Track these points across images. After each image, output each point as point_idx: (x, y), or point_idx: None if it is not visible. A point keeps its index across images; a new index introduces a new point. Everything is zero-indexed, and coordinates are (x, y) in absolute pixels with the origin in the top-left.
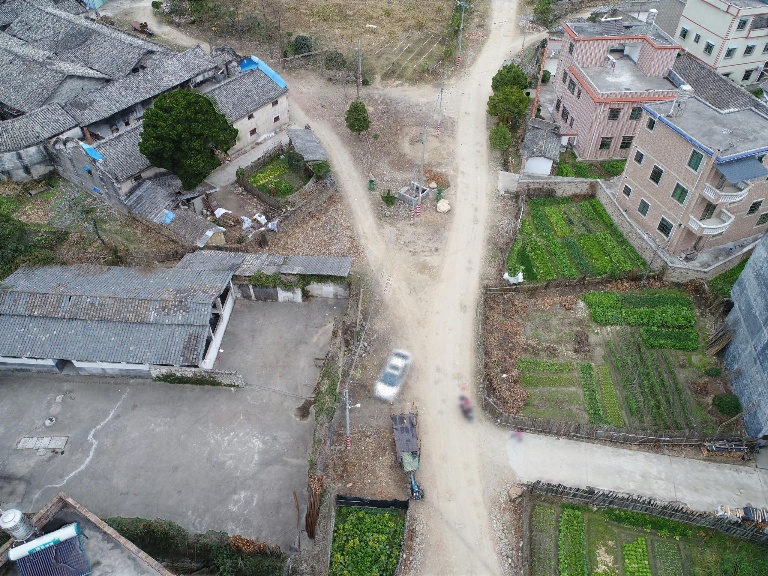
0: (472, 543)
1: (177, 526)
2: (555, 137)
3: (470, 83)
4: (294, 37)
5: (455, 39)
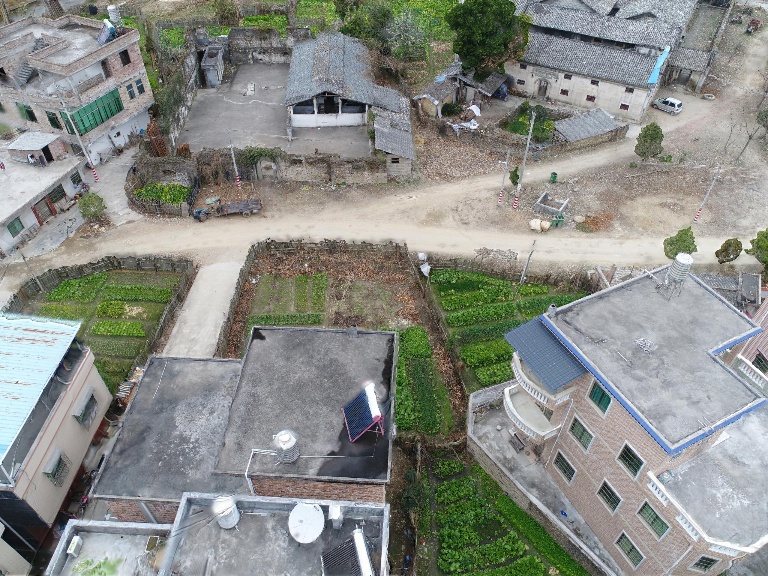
0: (160, 243)
1: (166, 107)
2: None
3: None
4: None
5: None
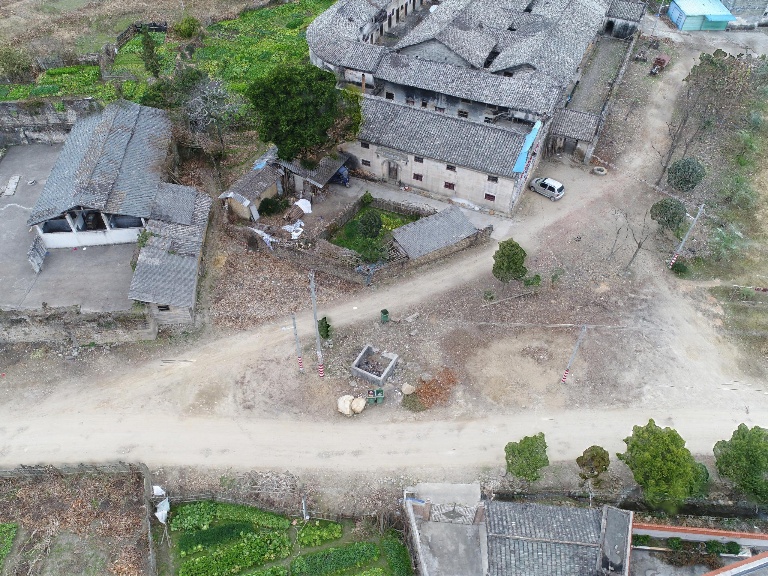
0: None
1: None
2: (584, 567)
3: None
4: (767, 175)
5: None
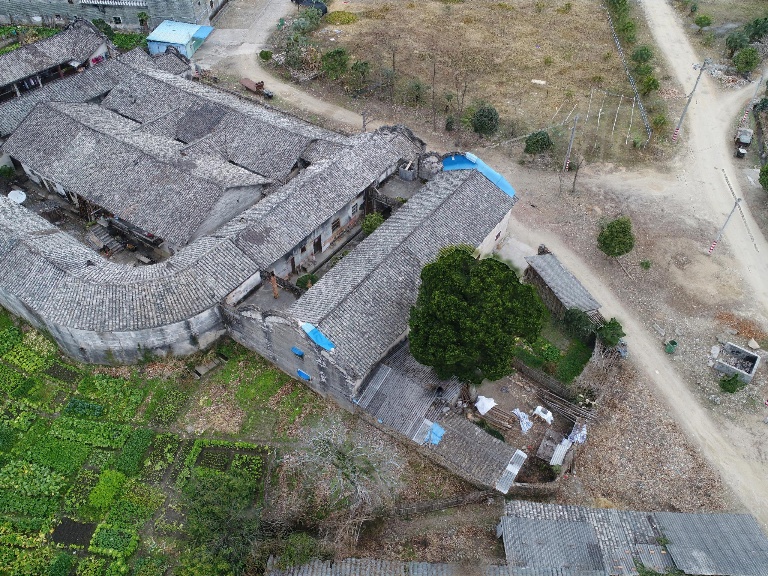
0: None
1: None
2: None
3: (702, 165)
4: None
5: (647, 98)
